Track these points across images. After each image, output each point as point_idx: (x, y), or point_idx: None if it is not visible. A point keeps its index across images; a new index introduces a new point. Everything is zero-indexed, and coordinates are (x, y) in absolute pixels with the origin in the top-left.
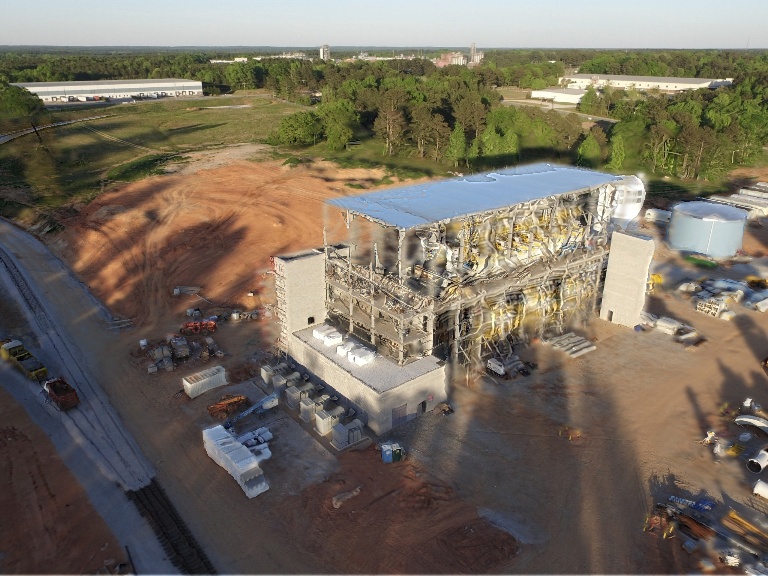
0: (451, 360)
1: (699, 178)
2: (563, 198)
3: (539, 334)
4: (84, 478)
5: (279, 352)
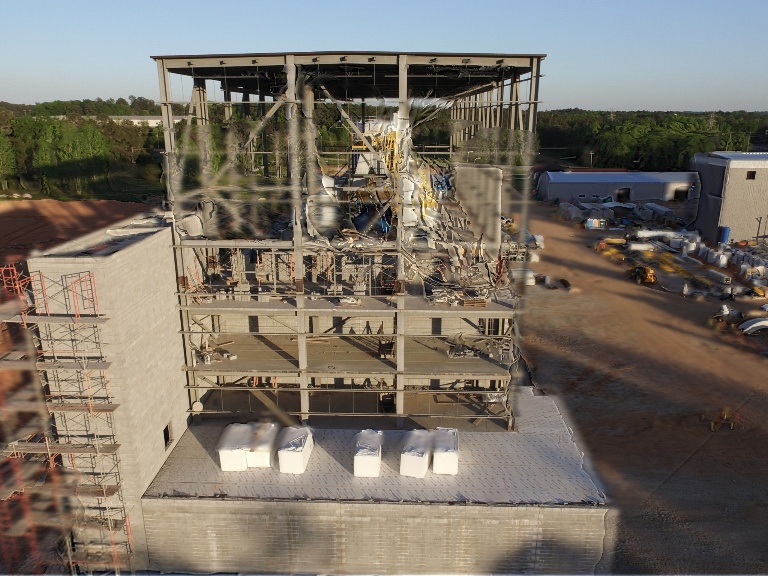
0: None
1: (293, 176)
2: None
3: None
4: None
5: None
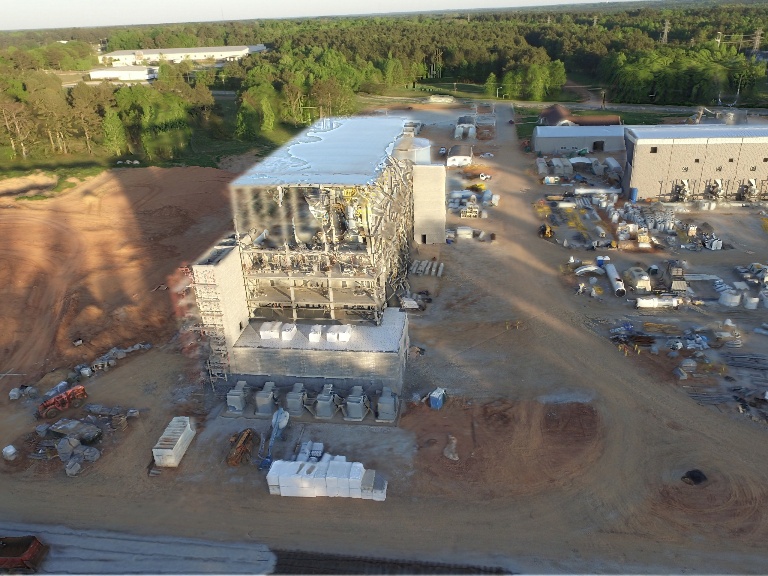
0: None
1: (335, 126)
2: None
3: None
4: None
5: (211, 377)
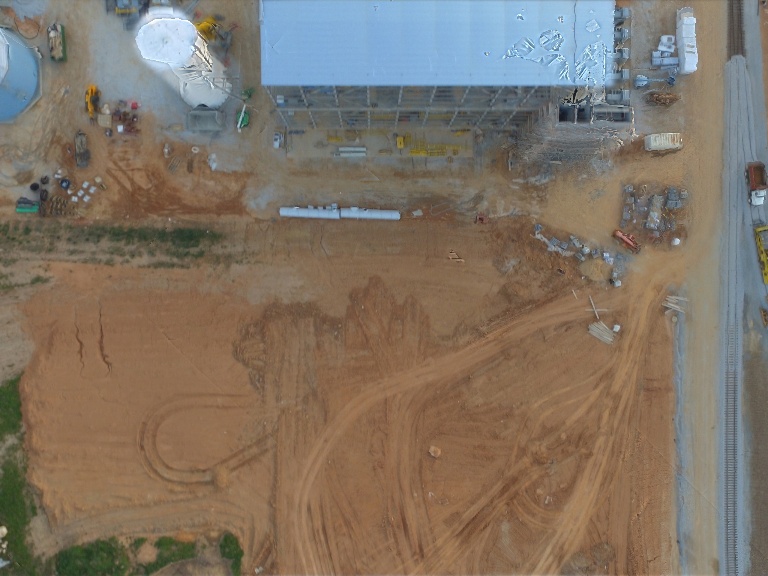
0: None
1: None
2: None
3: None
4: (761, 87)
5: None
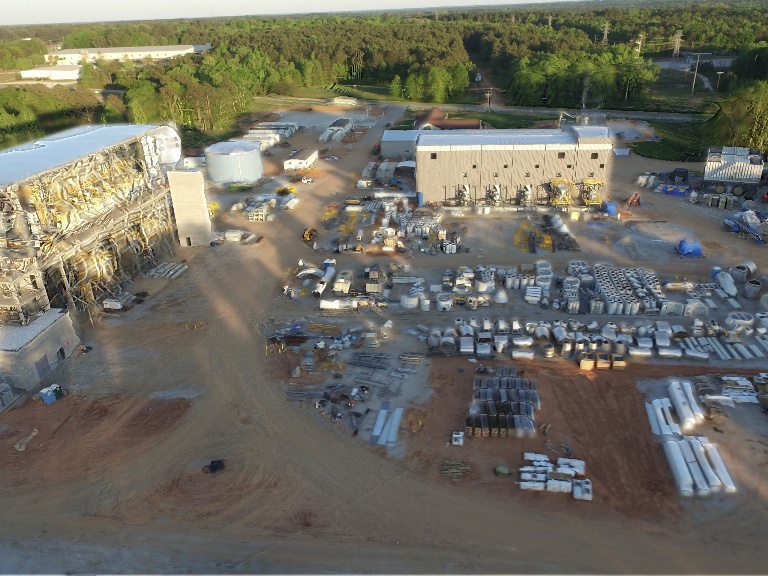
0: (70, 309)
1: (215, 128)
2: (116, 150)
3: (138, 270)
4: None
5: None
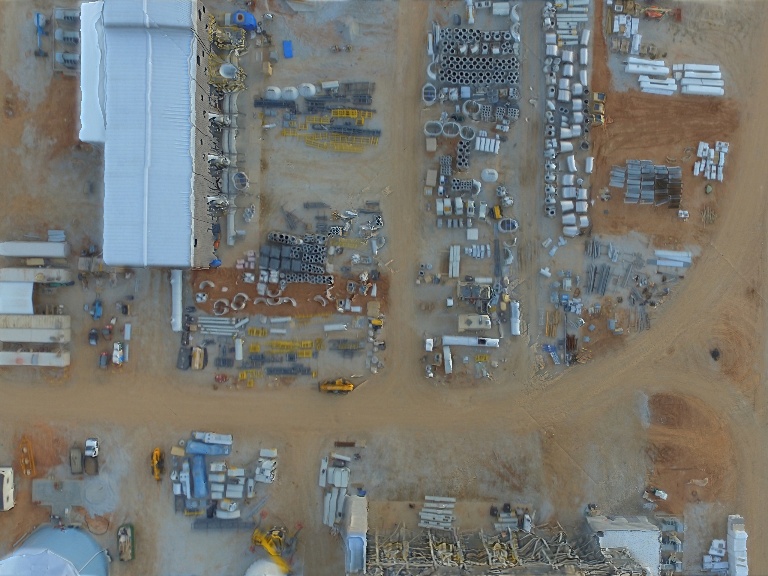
0: None
1: None
2: None
3: None
4: None
5: None
